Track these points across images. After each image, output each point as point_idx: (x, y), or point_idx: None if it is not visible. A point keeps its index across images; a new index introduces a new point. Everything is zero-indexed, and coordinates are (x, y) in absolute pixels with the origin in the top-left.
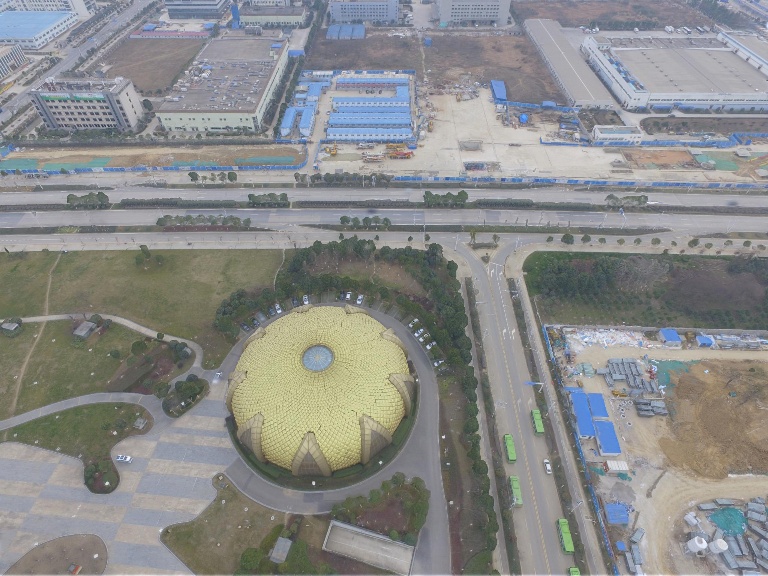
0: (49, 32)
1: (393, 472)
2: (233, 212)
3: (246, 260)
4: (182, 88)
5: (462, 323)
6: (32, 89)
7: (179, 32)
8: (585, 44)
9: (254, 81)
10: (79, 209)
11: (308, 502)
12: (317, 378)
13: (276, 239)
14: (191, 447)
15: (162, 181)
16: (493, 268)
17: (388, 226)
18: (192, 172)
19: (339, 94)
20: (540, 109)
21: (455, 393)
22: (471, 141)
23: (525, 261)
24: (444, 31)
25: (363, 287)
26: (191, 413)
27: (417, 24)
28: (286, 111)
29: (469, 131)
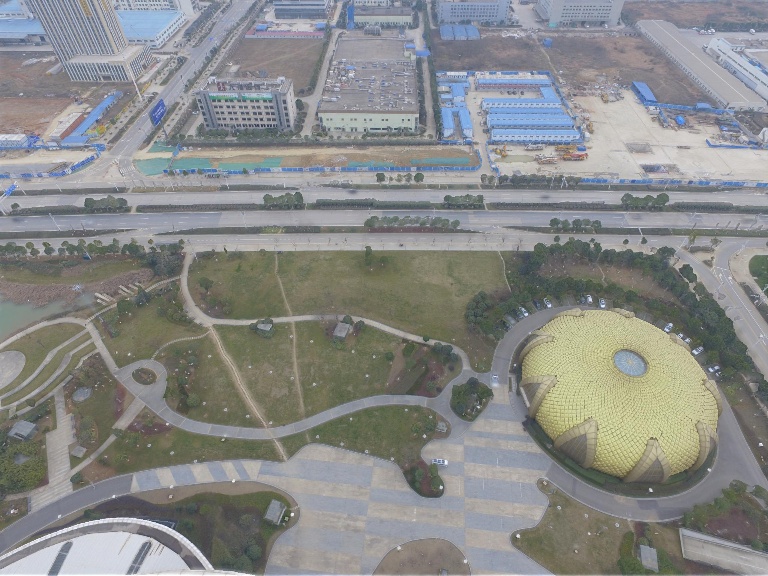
0: (166, 32)
1: (718, 480)
2: (430, 213)
3: (466, 262)
4: (335, 88)
5: (729, 328)
6: (201, 89)
7: (292, 32)
8: (712, 45)
9: (402, 81)
10: (275, 209)
11: (645, 509)
12: (641, 383)
13: (486, 241)
14: (500, 451)
15: (346, 181)
16: (720, 272)
17: (594, 229)
18: (380, 173)
19: (482, 95)
20: (692, 111)
21: (744, 399)
22: (638, 143)
23: (750, 265)
24: (556, 32)
25: (607, 290)
26: (484, 417)
27: (525, 25)
28: (442, 112)
29: (630, 133)
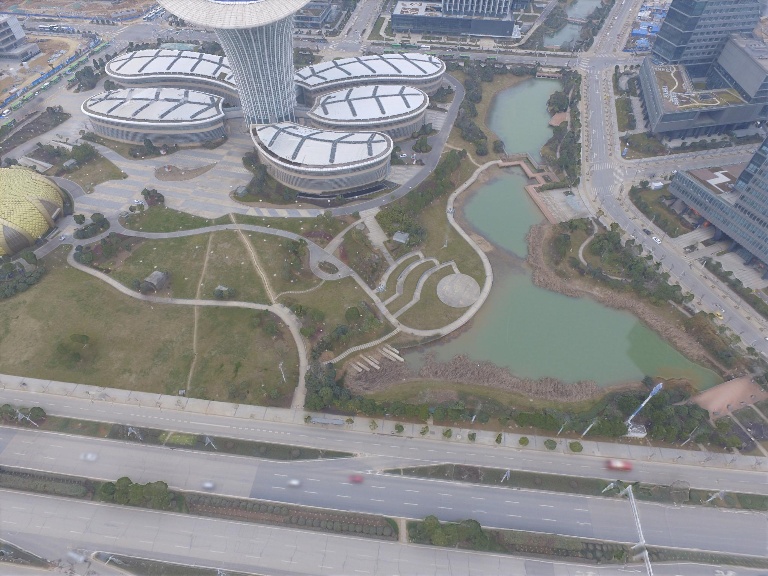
0: None
1: None
2: None
3: None
4: None
5: None
6: None
7: None
8: None
9: None
10: None
11: None
12: None
13: None
14: (100, 205)
15: None
16: None
17: None
18: None
19: None
20: None
21: None
22: None
23: None
24: None
25: None
26: None
27: None
28: None
29: None
